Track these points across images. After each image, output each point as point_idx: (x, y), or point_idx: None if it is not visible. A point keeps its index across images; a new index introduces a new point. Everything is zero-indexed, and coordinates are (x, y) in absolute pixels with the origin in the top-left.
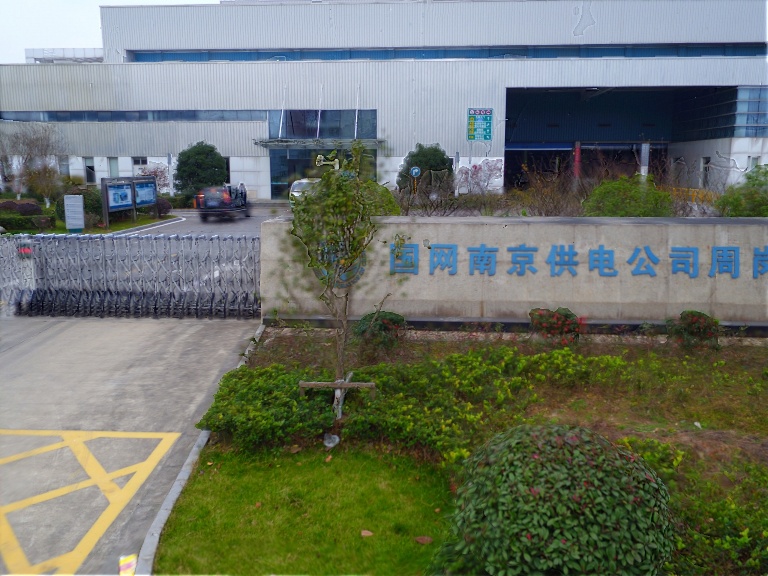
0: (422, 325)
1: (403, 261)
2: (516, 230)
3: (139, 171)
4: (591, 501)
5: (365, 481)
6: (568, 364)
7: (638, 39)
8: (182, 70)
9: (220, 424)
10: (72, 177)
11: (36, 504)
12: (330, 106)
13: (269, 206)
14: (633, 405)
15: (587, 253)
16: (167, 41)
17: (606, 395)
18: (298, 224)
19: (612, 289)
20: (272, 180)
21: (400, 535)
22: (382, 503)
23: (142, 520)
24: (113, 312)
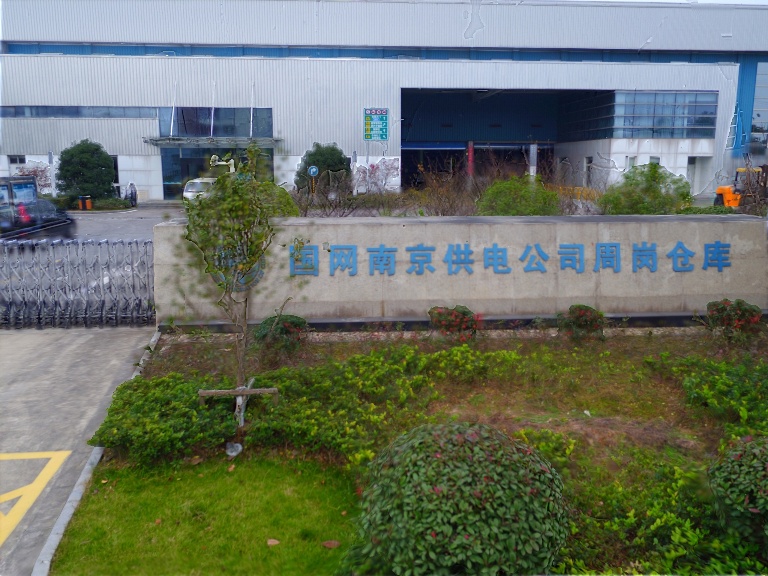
0: (324, 327)
1: (303, 263)
2: (414, 230)
3: (16, 170)
4: (491, 496)
5: (270, 489)
6: (467, 360)
7: (524, 43)
8: (62, 63)
9: (114, 439)
10: None
11: None
12: (224, 104)
13: (162, 207)
14: (528, 397)
15: (482, 251)
16: (44, 32)
17: (503, 389)
18: (193, 229)
19: (506, 286)
20: (164, 180)
21: (307, 541)
22: (288, 510)
23: (30, 547)
24: None
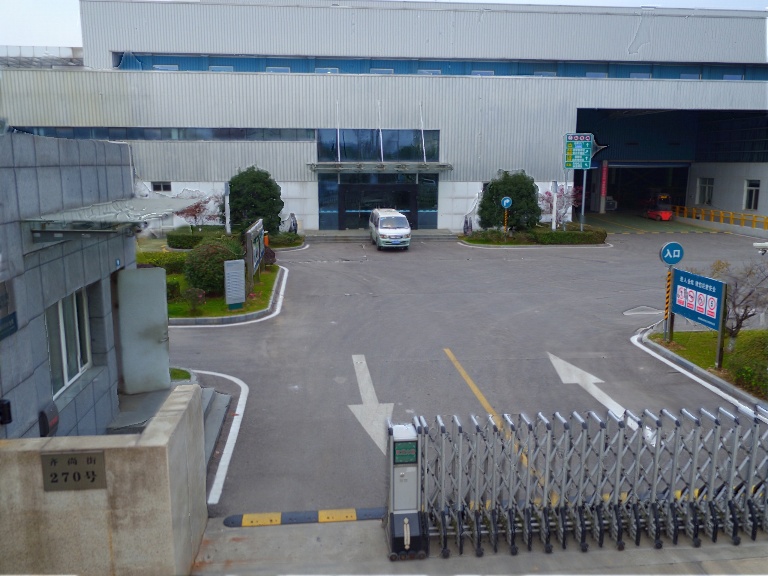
0: None
1: None
2: None
3: None
4: None
5: None
6: None
7: (669, 57)
8: (215, 81)
9: None
10: None
11: None
12: (388, 125)
13: (331, 240)
14: None
15: None
16: (162, 43)
17: None
18: None
19: None
20: (320, 208)
21: None
22: None
23: None
24: None
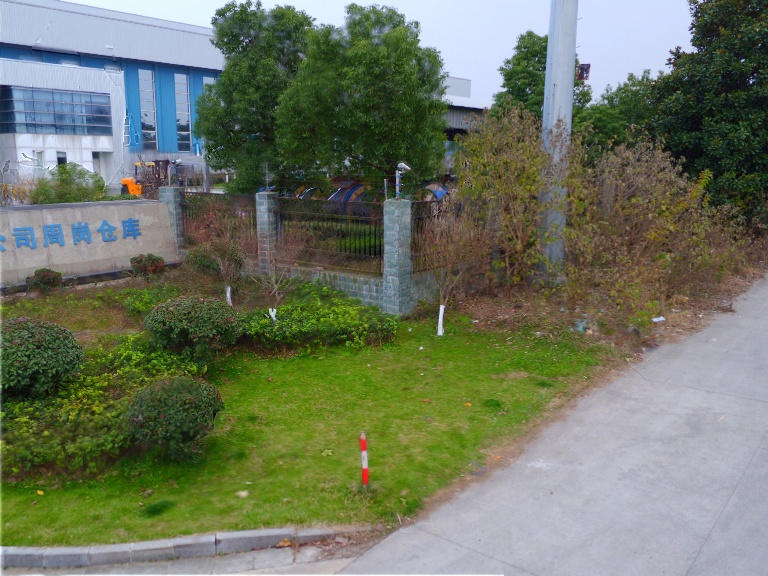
0: None
1: None
2: None
3: None
4: (44, 340)
5: None
6: None
7: None
8: None
9: None
10: None
11: None
12: None
13: None
14: None
15: None
16: None
17: None
18: None
19: None
20: None
21: None
22: None
23: None
24: None
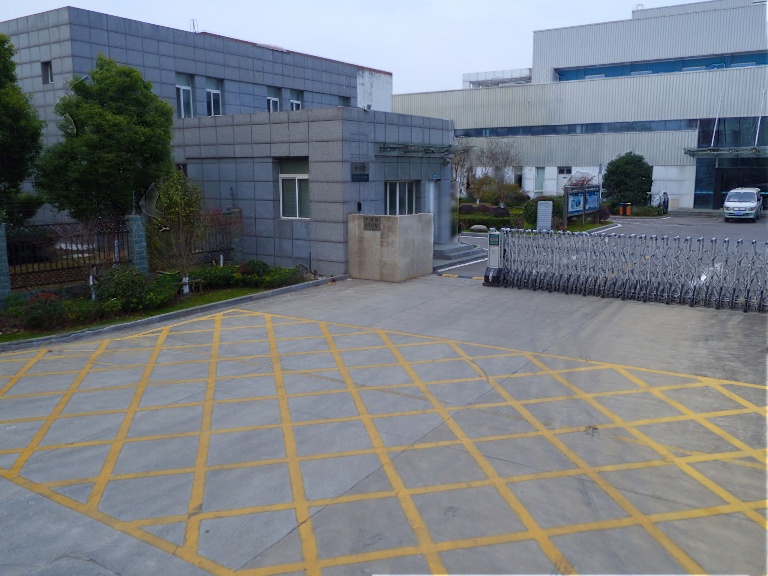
0: None
1: None
2: None
3: (563, 180)
4: None
5: None
6: None
7: None
8: (614, 85)
9: None
10: (523, 185)
11: (721, 416)
12: None
13: (694, 215)
14: None
15: None
16: (592, 57)
17: None
18: None
19: None
20: (696, 189)
21: None
22: None
23: None
24: (651, 298)
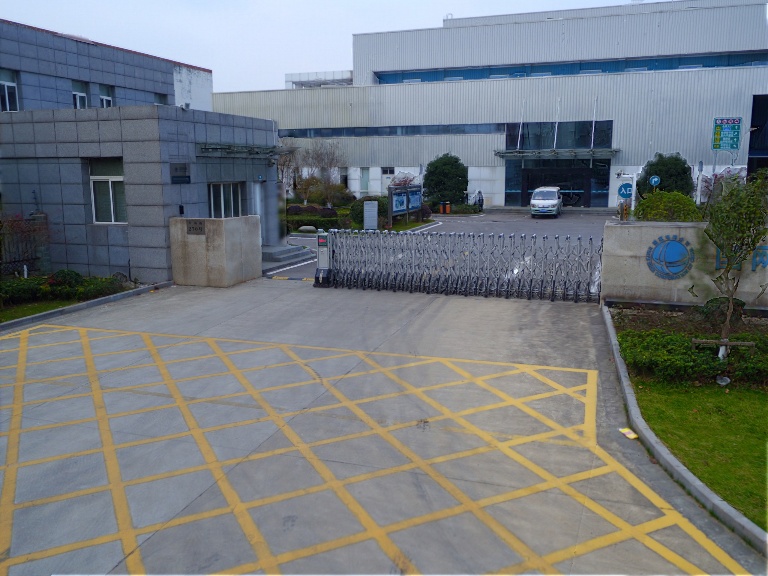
0: (745, 312)
1: None
2: None
3: (387, 180)
4: None
5: (765, 405)
6: None
7: None
8: (430, 89)
9: (646, 362)
10: (349, 186)
11: (536, 400)
12: (566, 118)
13: (506, 212)
14: None
15: None
16: (409, 62)
17: None
18: (719, 226)
19: None
20: (506, 188)
21: None
22: None
23: (615, 413)
24: (471, 292)
